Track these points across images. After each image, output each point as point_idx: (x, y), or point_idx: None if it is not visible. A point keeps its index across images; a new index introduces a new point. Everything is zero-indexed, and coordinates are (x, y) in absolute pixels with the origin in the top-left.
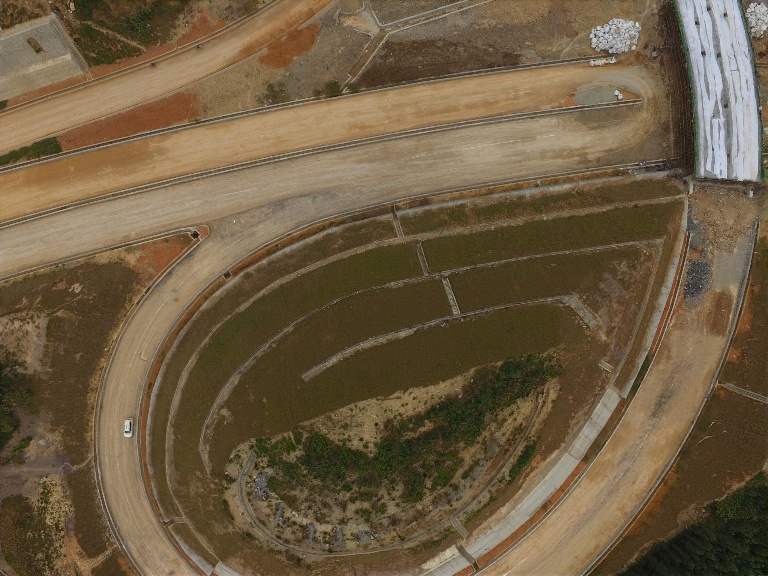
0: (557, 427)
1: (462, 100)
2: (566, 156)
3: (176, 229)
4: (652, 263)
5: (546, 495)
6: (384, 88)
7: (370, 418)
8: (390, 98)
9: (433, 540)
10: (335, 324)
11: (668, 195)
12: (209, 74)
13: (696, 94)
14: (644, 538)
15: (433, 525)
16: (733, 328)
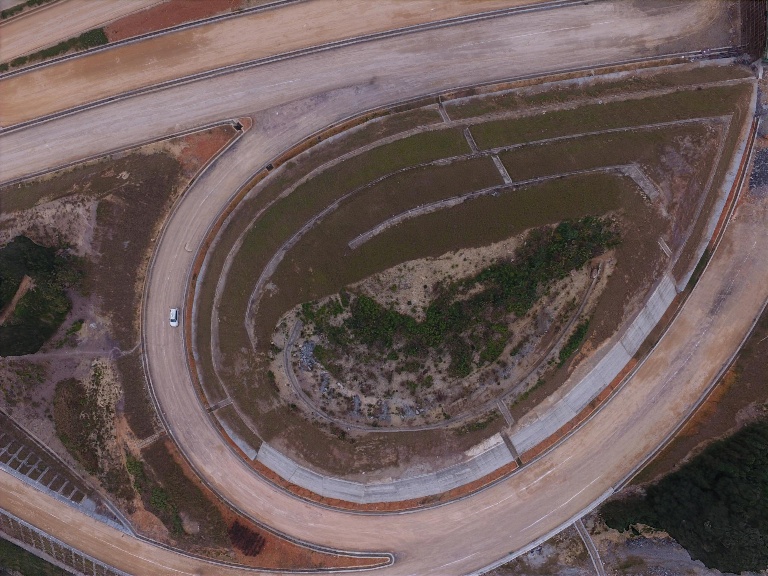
0: (611, 310)
1: None
2: (622, 44)
3: (219, 121)
4: (718, 141)
5: (595, 390)
6: None
7: (419, 280)
8: None
9: (478, 422)
10: (381, 197)
11: (735, 77)
12: None
13: None
14: (698, 438)
15: (478, 407)
16: None
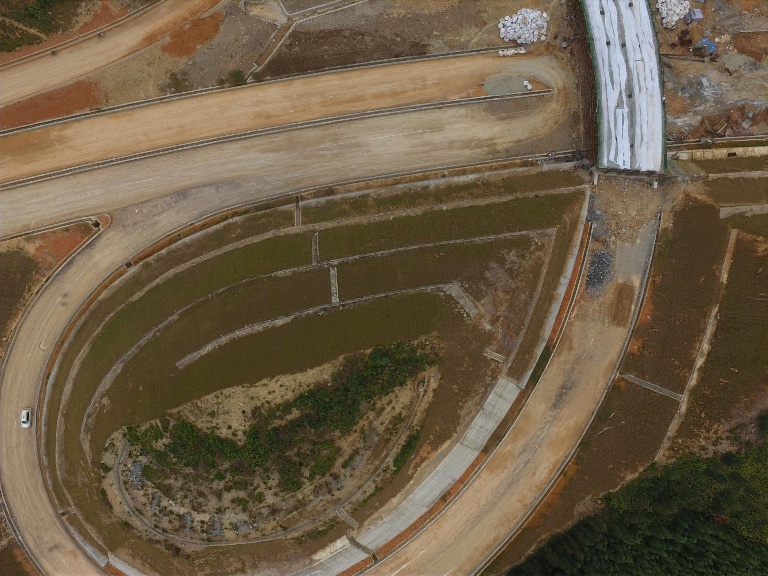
0: (444, 417)
1: (369, 90)
2: (474, 146)
3: (77, 218)
4: (544, 253)
5: (443, 486)
6: (289, 77)
7: (237, 406)
8: (296, 87)
9: (318, 530)
10: (216, 312)
11: (570, 185)
12: (111, 62)
13: (600, 84)
14: (542, 529)
15: (318, 515)
16: (634, 319)
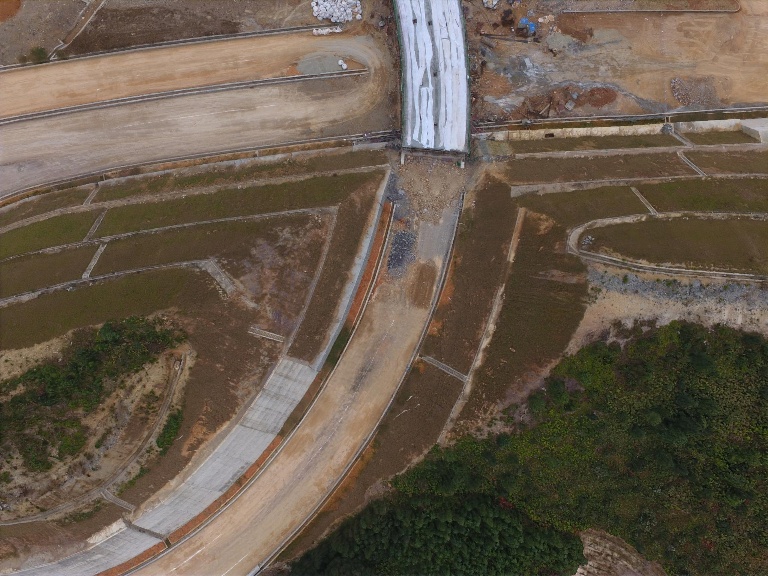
0: (213, 397)
1: (179, 68)
2: (288, 126)
3: None
4: (326, 231)
5: (233, 469)
6: (94, 55)
7: None
8: (102, 65)
9: (83, 512)
10: None
11: (371, 164)
12: None
13: (406, 62)
14: (336, 514)
15: (82, 497)
16: (435, 300)
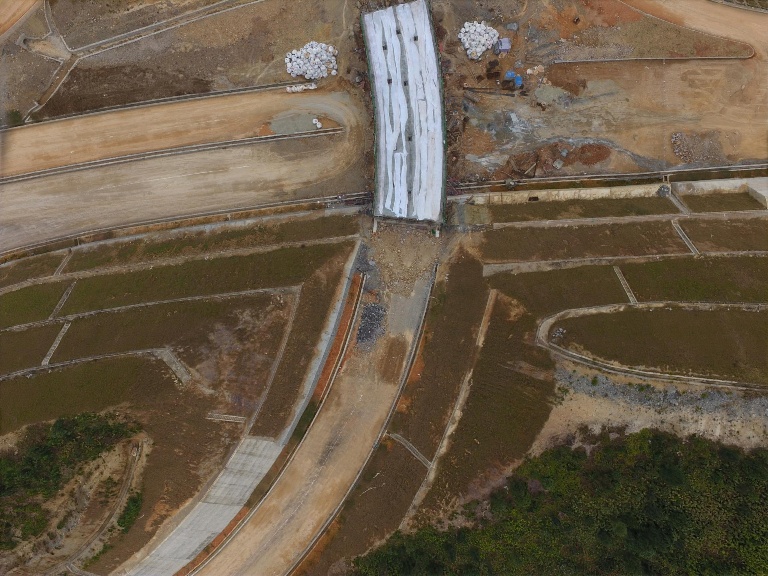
0: (173, 478)
1: (151, 129)
2: (260, 188)
3: None
4: (288, 311)
5: (200, 540)
6: (68, 117)
7: None
8: (76, 127)
9: None
10: None
11: (340, 235)
12: None
13: (379, 126)
14: None
15: (49, 569)
16: (404, 376)
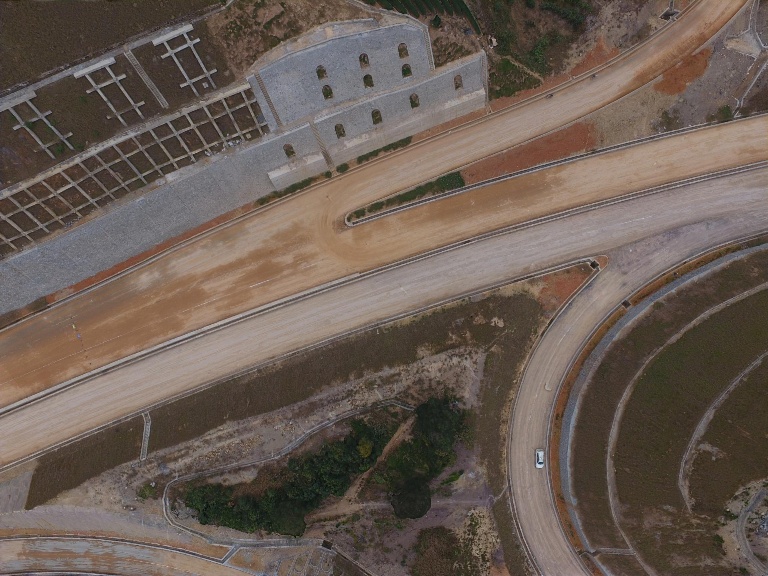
0: None
1: None
2: None
3: (576, 260)
4: None
5: None
6: None
7: None
8: None
9: None
10: None
11: None
12: (605, 103)
13: None
14: None
15: None
16: None
